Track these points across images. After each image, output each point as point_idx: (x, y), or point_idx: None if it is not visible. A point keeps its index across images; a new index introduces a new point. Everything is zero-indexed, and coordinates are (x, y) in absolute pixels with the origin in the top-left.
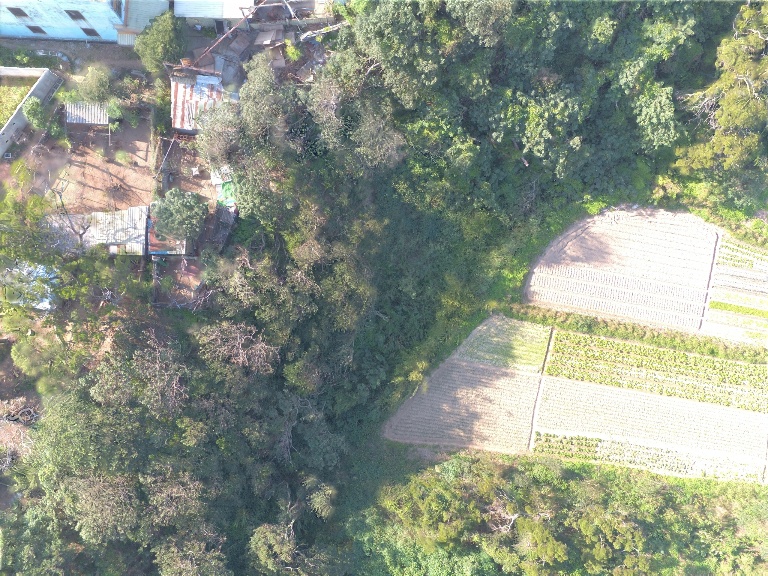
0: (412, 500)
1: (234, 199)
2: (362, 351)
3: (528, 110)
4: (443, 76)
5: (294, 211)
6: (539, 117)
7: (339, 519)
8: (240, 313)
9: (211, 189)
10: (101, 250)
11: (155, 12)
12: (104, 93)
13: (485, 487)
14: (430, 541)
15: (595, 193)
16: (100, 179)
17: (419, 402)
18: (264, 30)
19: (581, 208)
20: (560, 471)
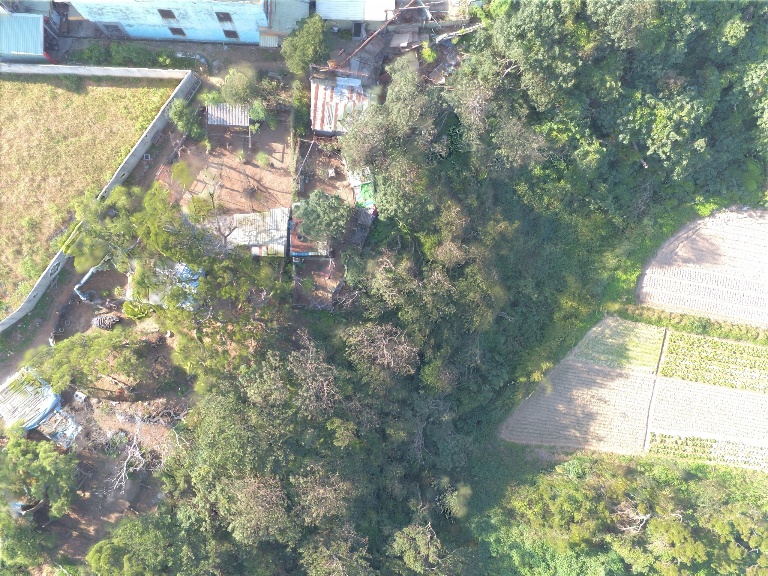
0: (542, 501)
1: (373, 201)
2: (482, 352)
3: (656, 112)
4: (575, 78)
5: (435, 213)
6: (667, 119)
7: (465, 520)
8: (385, 314)
9: (346, 191)
10: (244, 251)
11: (296, 14)
12: (248, 95)
13: (613, 488)
14: (562, 542)
15: (707, 195)
16: (237, 181)
17: (535, 403)
18: (399, 32)
19: (692, 210)
20: (678, 472)
